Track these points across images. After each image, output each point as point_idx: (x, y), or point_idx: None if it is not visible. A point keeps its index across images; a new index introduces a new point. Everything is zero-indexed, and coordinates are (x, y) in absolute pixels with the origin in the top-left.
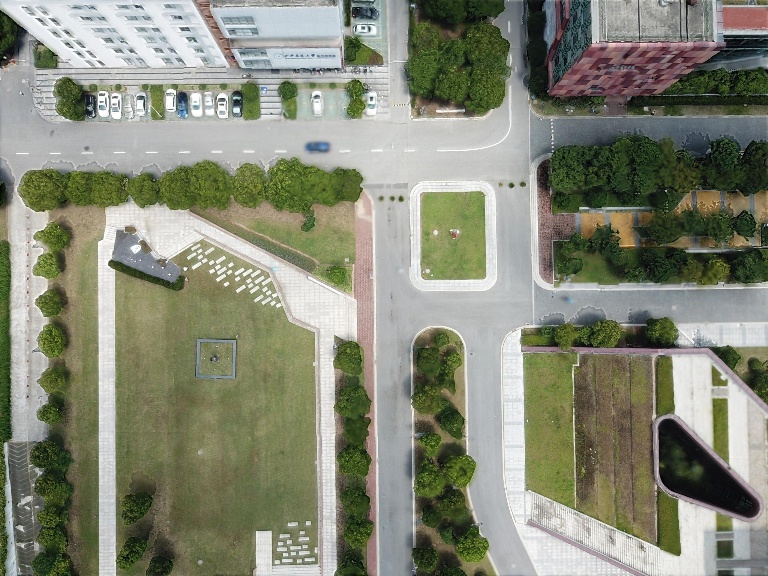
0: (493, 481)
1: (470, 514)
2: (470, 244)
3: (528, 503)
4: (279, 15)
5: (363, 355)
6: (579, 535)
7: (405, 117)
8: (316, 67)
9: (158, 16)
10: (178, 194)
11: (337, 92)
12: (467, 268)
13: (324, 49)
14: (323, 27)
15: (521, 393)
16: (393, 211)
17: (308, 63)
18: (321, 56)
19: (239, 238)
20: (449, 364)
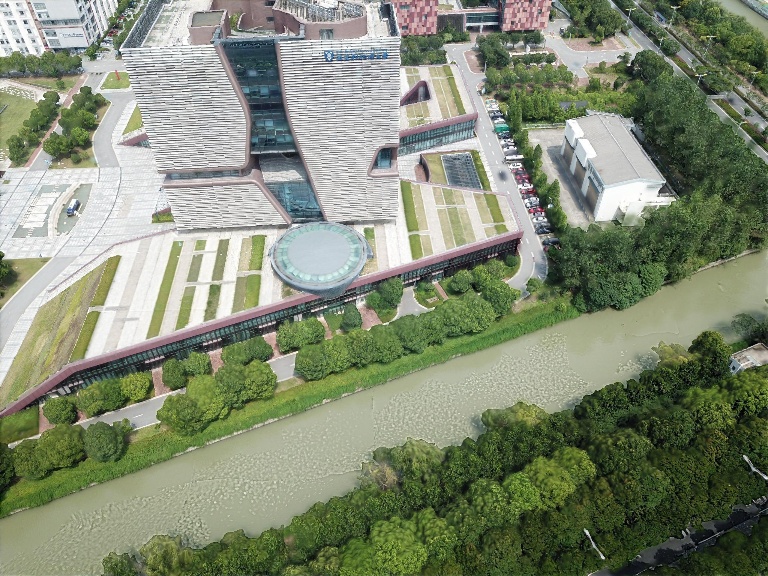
0: (107, 134)
1: (91, 142)
2: (125, 81)
3: (121, 138)
4: (53, 2)
5: (63, 107)
6: (137, 134)
7: (112, 60)
8: (79, 46)
9: (15, 11)
10: (2, 60)
11: (87, 56)
12: (121, 86)
13: (77, 29)
14: (71, 10)
15: (132, 112)
16: (96, 77)
17: (74, 42)
18: (77, 35)
19: (25, 84)
20: (97, 97)
